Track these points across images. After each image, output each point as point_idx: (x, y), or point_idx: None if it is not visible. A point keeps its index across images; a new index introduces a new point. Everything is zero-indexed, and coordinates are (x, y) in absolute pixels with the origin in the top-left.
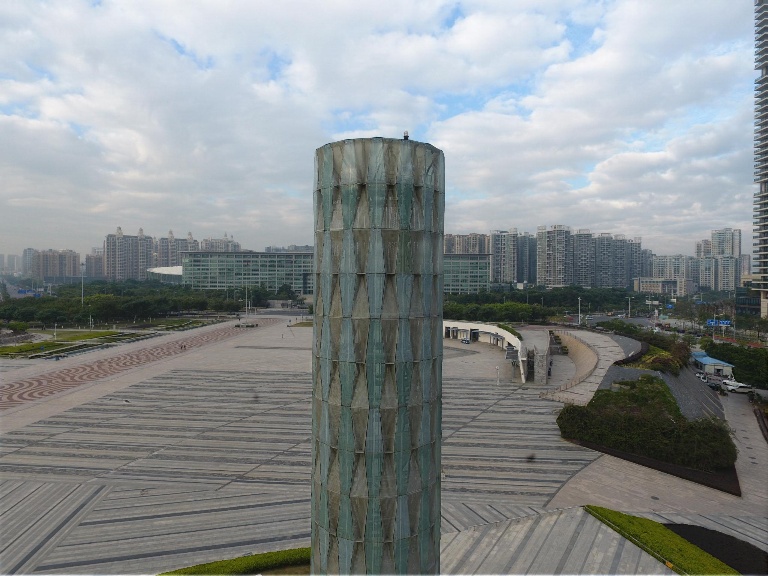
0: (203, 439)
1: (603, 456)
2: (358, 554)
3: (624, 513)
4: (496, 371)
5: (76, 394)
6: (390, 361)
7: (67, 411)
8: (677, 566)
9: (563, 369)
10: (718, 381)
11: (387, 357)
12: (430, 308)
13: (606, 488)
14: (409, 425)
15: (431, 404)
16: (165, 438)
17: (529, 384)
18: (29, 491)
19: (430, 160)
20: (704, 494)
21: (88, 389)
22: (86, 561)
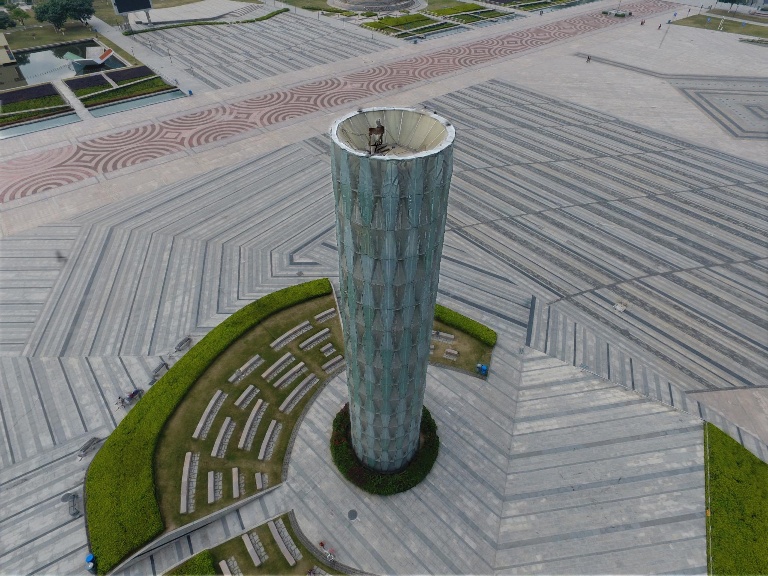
0: (460, 178)
1: None
2: None
3: None
4: None
5: (407, 93)
6: (360, 301)
7: None
8: (711, 519)
9: None
10: None
11: None
12: (394, 280)
13: None
14: (373, 338)
15: (395, 332)
16: None
17: None
18: None
19: (395, 173)
20: None
21: (417, 89)
22: None
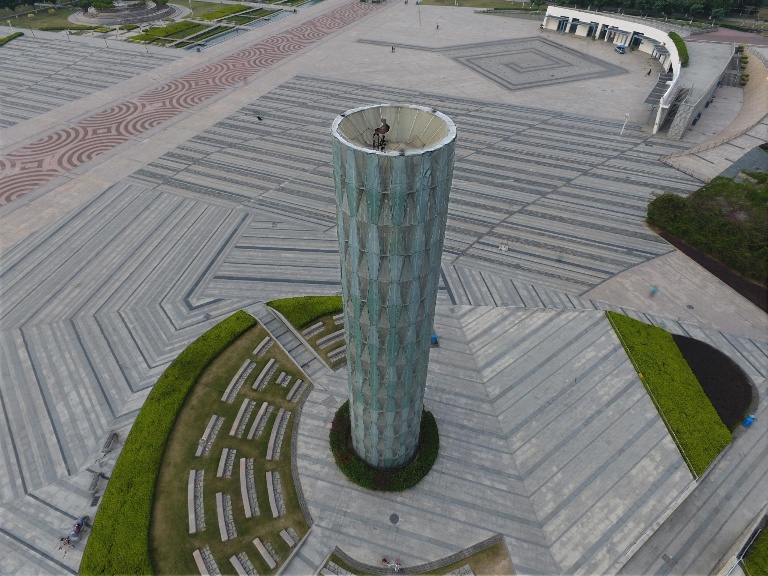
0: (318, 175)
1: (674, 252)
2: (366, 381)
3: (648, 316)
4: (629, 113)
5: (219, 104)
6: (385, 304)
7: (215, 126)
8: (645, 379)
9: (720, 114)
10: None
11: (383, 301)
12: (420, 272)
13: (650, 288)
14: (398, 336)
15: (418, 322)
16: (289, 169)
17: (659, 136)
18: (201, 211)
19: (428, 165)
20: (745, 312)
21: (227, 98)
22: (242, 277)
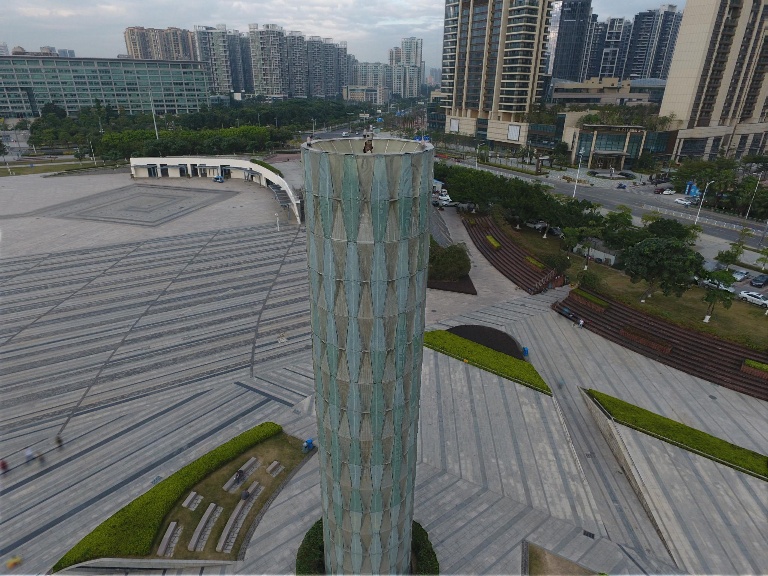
0: None
1: None
2: (385, 470)
3: None
4: None
5: None
6: (409, 340)
7: None
8: (471, 361)
9: None
10: (437, 199)
11: None
12: None
13: None
14: None
15: None
16: None
17: None
18: None
19: None
20: (458, 299)
21: None
22: None
